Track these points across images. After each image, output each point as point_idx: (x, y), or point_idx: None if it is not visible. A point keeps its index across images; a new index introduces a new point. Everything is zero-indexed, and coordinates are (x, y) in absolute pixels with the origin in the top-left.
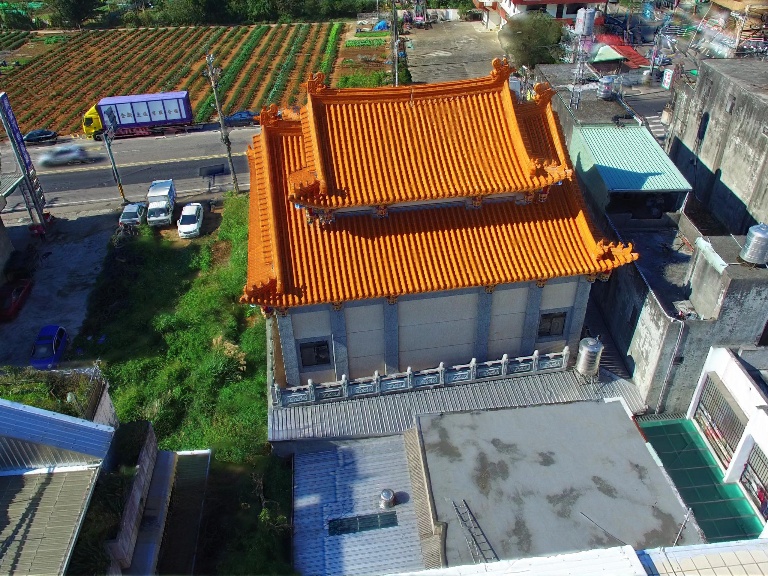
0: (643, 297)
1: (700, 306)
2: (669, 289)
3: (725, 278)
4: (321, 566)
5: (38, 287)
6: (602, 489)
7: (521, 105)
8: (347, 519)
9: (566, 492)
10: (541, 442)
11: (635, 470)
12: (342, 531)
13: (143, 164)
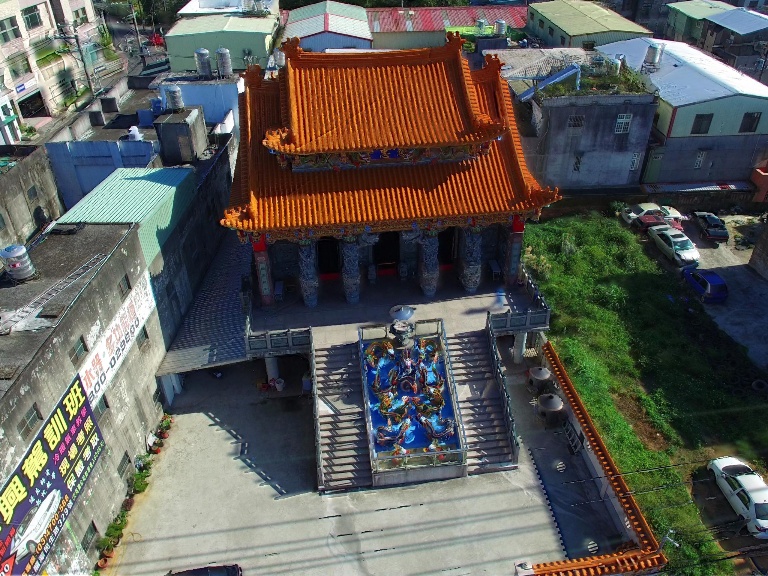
0: None
1: None
2: (203, 165)
3: None
4: None
5: None
6: None
7: None
8: None
9: None
10: None
11: None
12: None
13: None
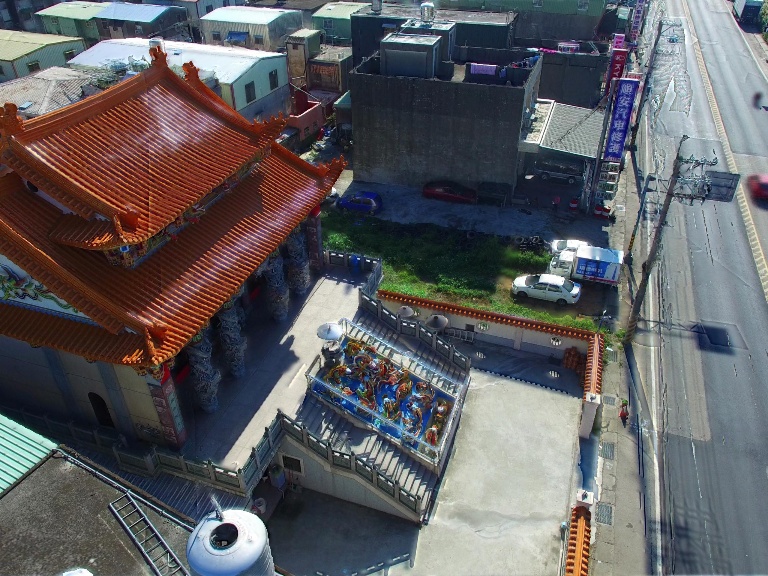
0: None
1: None
2: None
3: None
4: None
5: (469, 207)
6: None
7: None
8: None
9: None
10: None
11: None
12: None
13: (763, 281)
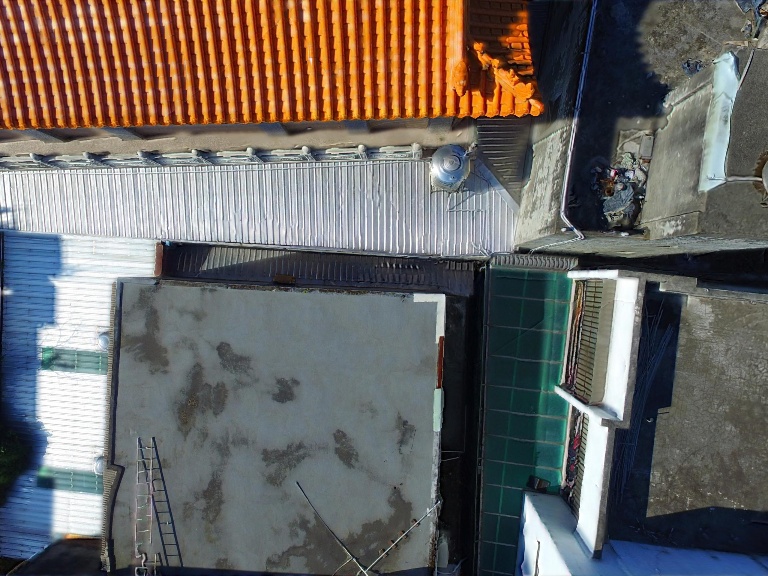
0: (565, 116)
1: (655, 173)
2: (637, 89)
3: (691, 216)
4: (30, 406)
5: None
6: (340, 452)
7: None
8: (63, 351)
9: (290, 448)
10: (287, 360)
11: (399, 430)
12: (56, 366)
13: None
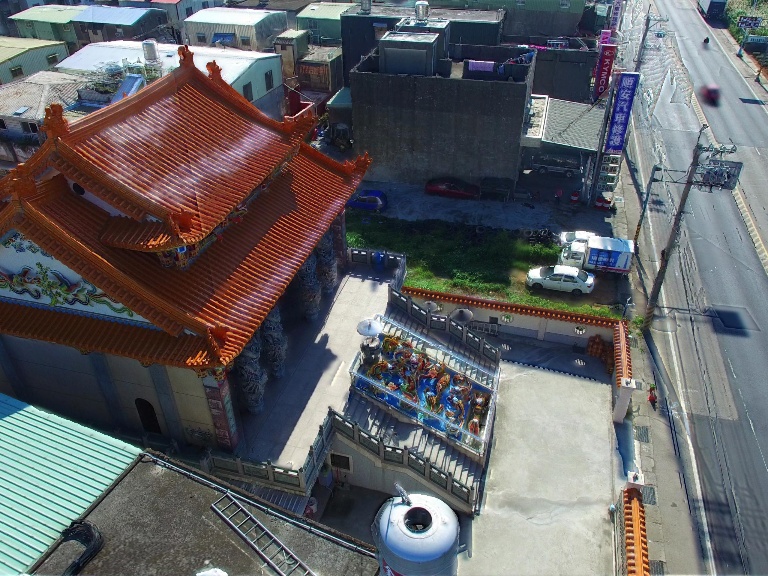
0: None
1: None
2: None
3: None
4: None
5: (472, 202)
6: None
7: (46, 180)
8: None
9: None
10: None
11: None
12: None
13: (765, 265)
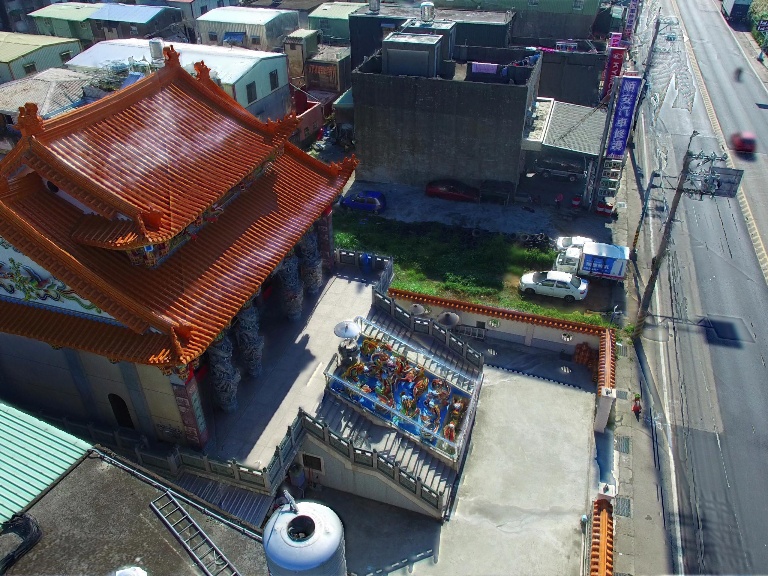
0: None
1: None
2: None
3: None
4: None
5: (472, 205)
6: None
7: (20, 177)
8: None
9: None
10: None
11: None
12: None
13: (766, 275)
